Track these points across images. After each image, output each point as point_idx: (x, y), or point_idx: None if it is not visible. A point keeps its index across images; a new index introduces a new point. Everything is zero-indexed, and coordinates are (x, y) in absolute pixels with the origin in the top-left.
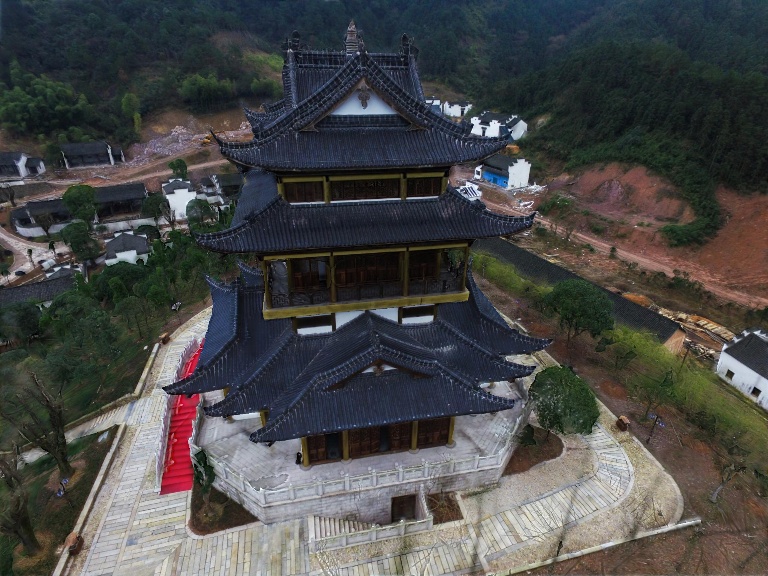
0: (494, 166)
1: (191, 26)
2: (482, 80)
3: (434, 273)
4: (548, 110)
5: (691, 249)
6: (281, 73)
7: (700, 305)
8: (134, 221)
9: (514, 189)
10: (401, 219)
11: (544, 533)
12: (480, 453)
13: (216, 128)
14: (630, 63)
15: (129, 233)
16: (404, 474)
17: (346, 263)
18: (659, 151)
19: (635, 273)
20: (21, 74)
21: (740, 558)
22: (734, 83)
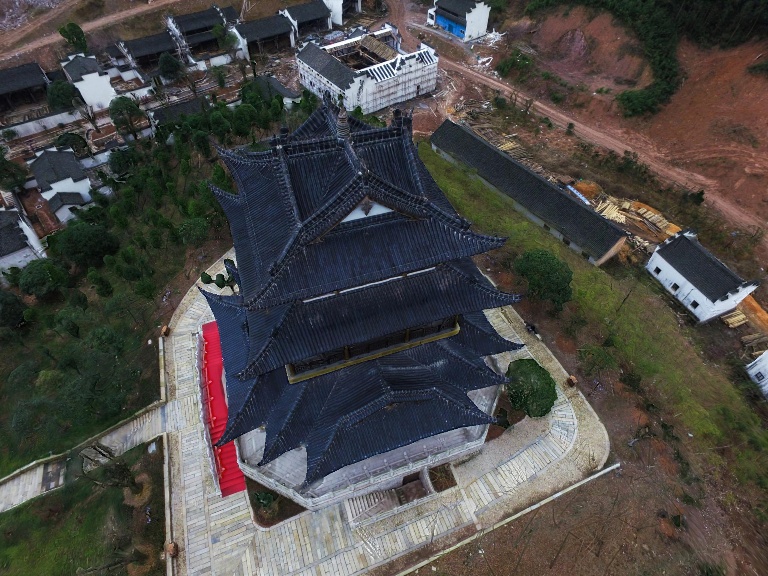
0: (450, 11)
1: None
2: None
3: None
4: None
5: (644, 118)
6: None
7: (643, 188)
8: (45, 119)
9: (471, 40)
10: (405, 299)
11: (514, 488)
12: (467, 434)
13: None
14: None
15: (52, 150)
16: (413, 465)
17: None
18: None
19: (589, 154)
20: None
21: (642, 490)
22: None
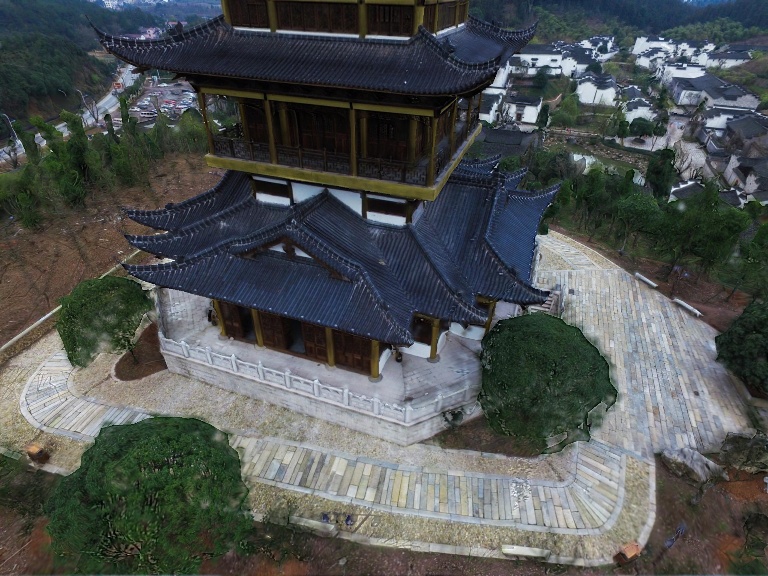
0: None
1: None
2: None
3: None
4: None
5: None
6: None
7: None
8: None
9: None
10: None
11: None
12: None
13: None
14: None
15: None
16: None
17: None
18: None
19: None
20: None
21: None
22: None
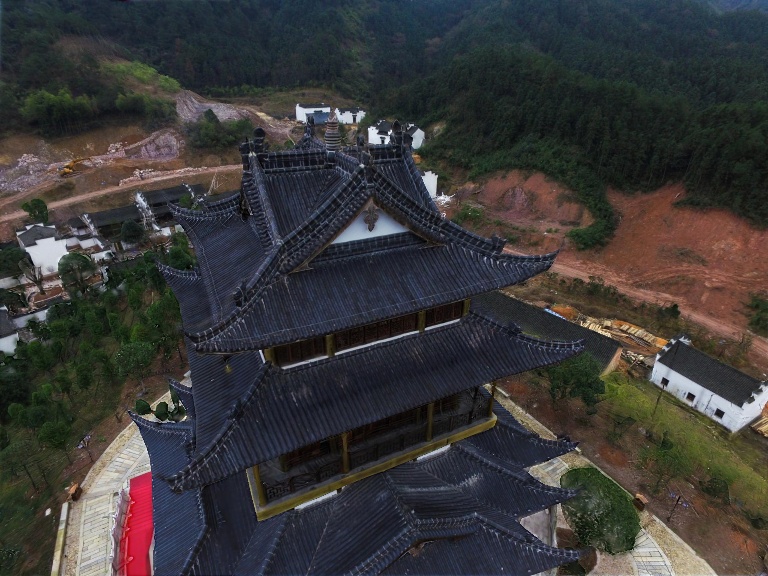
0: None
1: (26, 31)
2: (369, 84)
3: (452, 399)
4: (442, 118)
5: (596, 251)
6: (150, 85)
7: (617, 308)
8: None
9: None
10: (426, 361)
11: None
12: None
13: (77, 153)
14: (513, 71)
15: None
16: None
17: None
18: (553, 158)
19: (555, 282)
20: None
21: None
22: (607, 91)
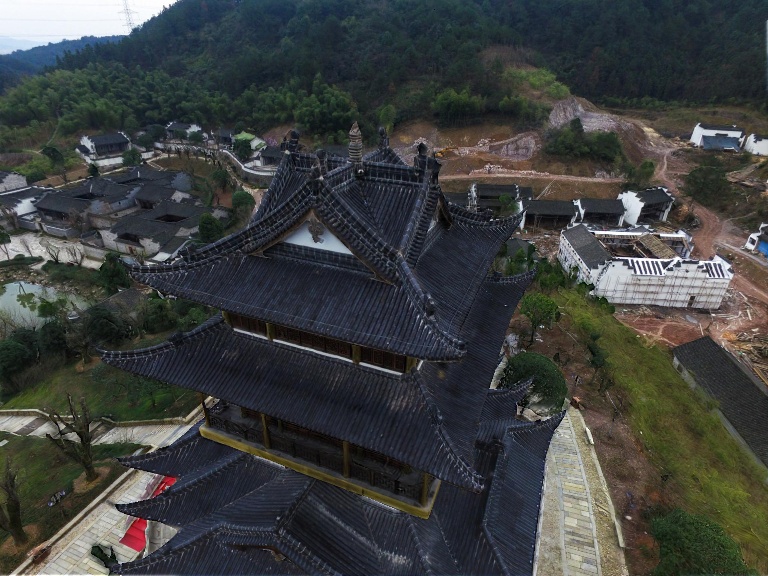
0: None
1: (465, 42)
2: None
3: None
4: None
5: None
6: (539, 90)
7: None
8: None
9: None
10: (335, 391)
11: None
12: None
13: (455, 143)
14: None
15: None
16: None
17: None
18: None
19: None
20: (320, 84)
21: None
22: None
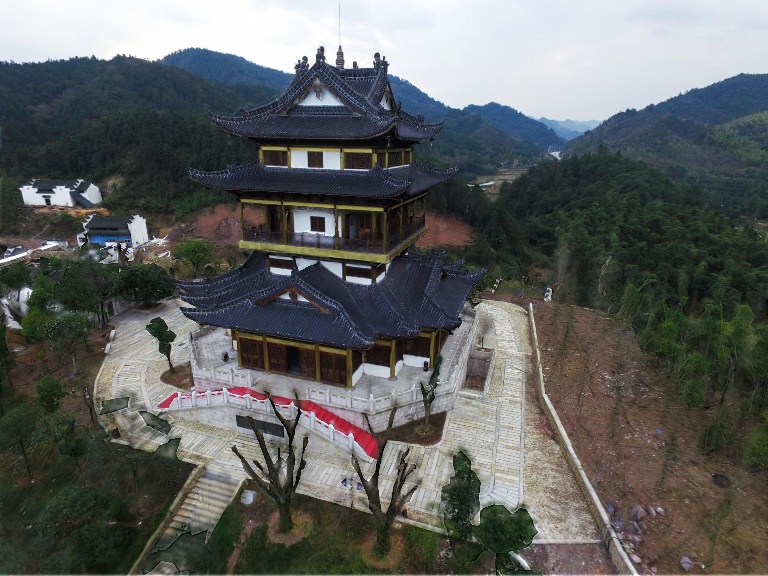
0: (106, 228)
1: None
2: None
3: (407, 220)
4: (115, 171)
5: None
6: None
7: None
8: None
9: (140, 246)
10: None
11: (514, 335)
12: (466, 321)
13: None
14: (178, 127)
15: None
16: None
17: (388, 217)
18: None
19: None
20: None
21: (551, 304)
22: None
